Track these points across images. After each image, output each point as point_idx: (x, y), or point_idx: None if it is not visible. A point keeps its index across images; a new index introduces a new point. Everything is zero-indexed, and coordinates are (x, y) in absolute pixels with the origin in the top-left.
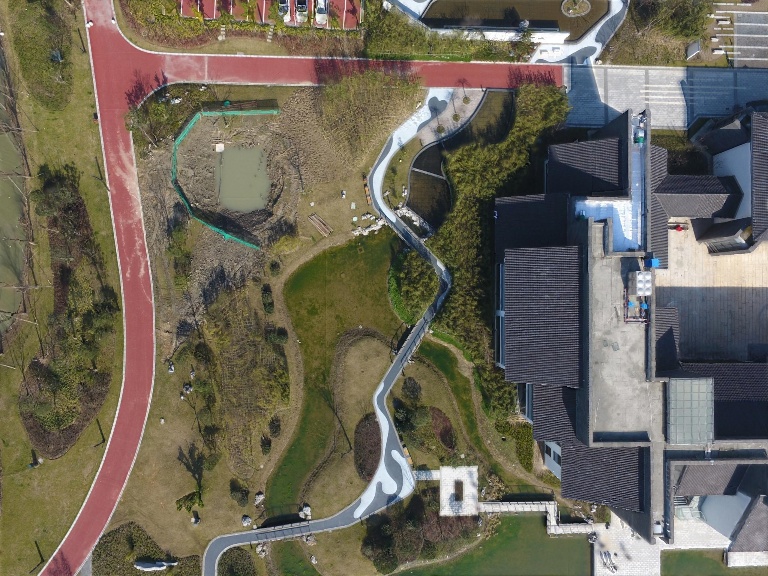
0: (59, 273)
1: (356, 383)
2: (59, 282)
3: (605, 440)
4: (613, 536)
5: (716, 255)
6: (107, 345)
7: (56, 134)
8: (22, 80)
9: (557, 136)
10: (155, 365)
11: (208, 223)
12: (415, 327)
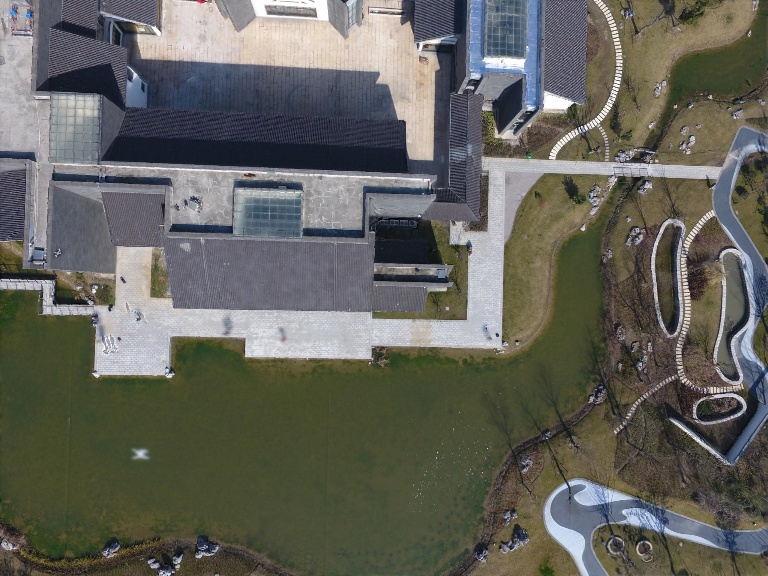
0: None
1: None
2: None
3: None
4: (117, 320)
5: (236, 28)
6: None
7: None
8: None
9: None
10: None
11: None
12: None
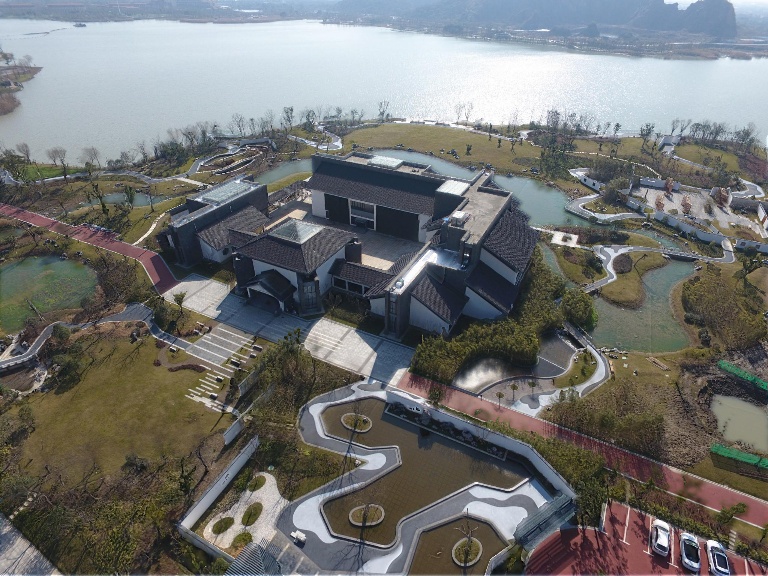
0: None
1: (629, 286)
2: None
3: (502, 194)
4: None
5: None
6: None
7: None
8: None
9: None
10: None
11: None
12: None
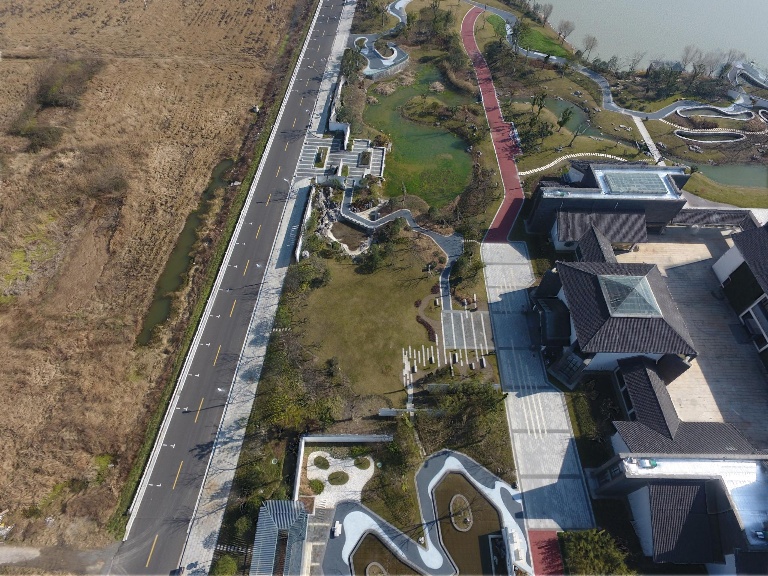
0: None
1: None
2: None
3: None
4: None
5: None
6: None
7: None
8: None
9: None
10: None
11: None
12: None
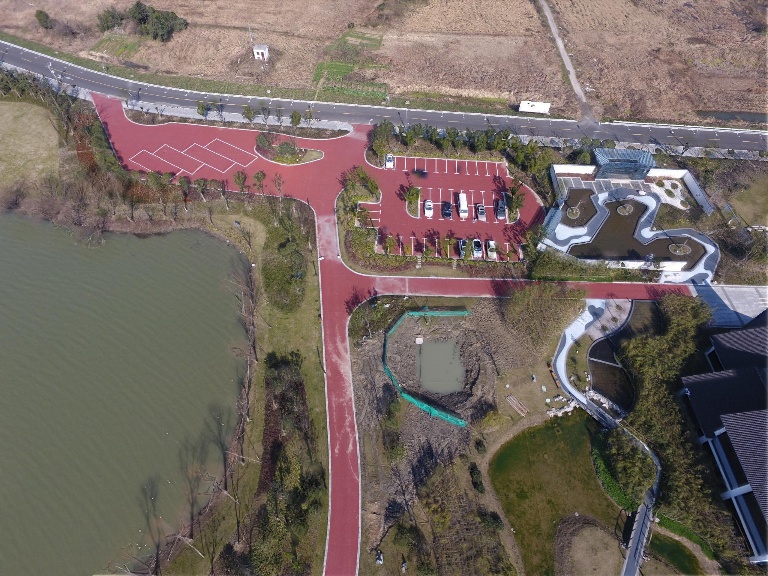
0: (269, 448)
1: None
2: (268, 457)
3: None
4: None
5: None
6: (311, 528)
7: (286, 329)
8: (264, 293)
9: (707, 333)
10: (359, 555)
11: (414, 401)
12: (638, 514)
